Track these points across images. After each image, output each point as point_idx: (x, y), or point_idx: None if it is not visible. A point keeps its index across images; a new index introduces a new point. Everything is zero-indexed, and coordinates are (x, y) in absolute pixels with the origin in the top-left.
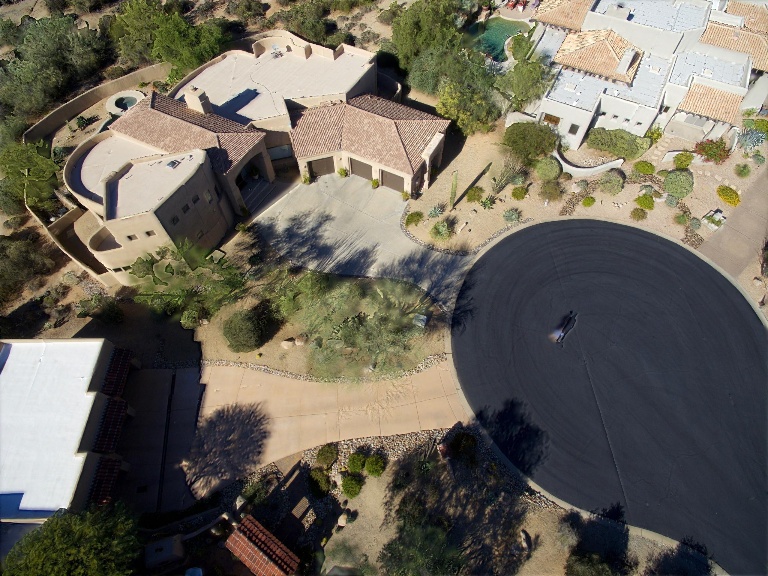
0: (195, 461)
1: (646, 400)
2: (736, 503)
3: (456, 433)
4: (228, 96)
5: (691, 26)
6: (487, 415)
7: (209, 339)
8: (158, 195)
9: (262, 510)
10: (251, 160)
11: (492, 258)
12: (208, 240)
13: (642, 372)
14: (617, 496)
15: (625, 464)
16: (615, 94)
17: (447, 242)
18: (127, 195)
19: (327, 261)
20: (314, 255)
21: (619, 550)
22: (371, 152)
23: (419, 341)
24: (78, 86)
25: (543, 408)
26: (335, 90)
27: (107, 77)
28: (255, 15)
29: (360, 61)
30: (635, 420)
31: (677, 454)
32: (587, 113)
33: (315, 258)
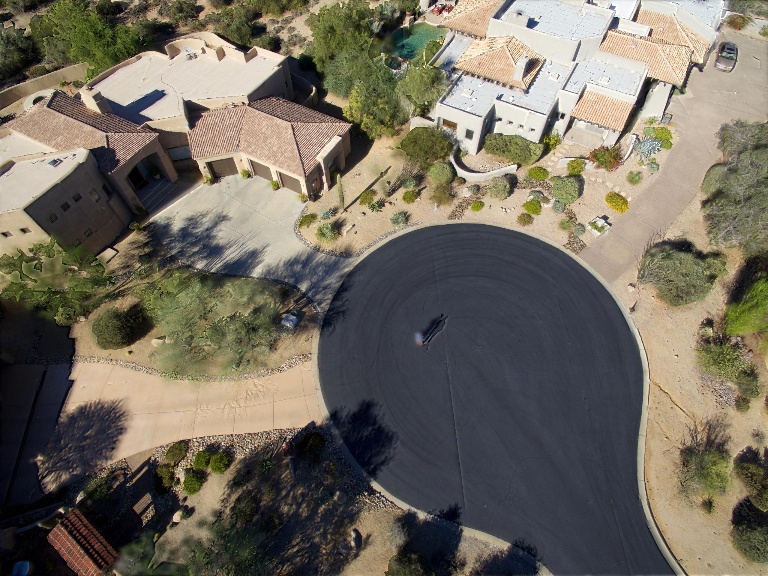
0: (50, 456)
1: (501, 403)
2: (573, 506)
3: (307, 432)
4: (135, 96)
5: (591, 34)
6: (341, 415)
7: (84, 336)
8: (33, 193)
9: (103, 505)
10: (150, 160)
11: (374, 260)
12: (99, 238)
13: (502, 375)
14: (456, 497)
15: (470, 466)
16: (510, 100)
17: (333, 244)
18: (3, 192)
19: (216, 261)
20: (204, 255)
21: (448, 551)
22: (266, 154)
23: (287, 341)
24: (1, 84)
25: (398, 409)
26: (241, 92)
27: (30, 76)
28: (187, 17)
29: (271, 64)
30: (487, 423)
31: (523, 457)
32: (477, 118)
33: (205, 258)
